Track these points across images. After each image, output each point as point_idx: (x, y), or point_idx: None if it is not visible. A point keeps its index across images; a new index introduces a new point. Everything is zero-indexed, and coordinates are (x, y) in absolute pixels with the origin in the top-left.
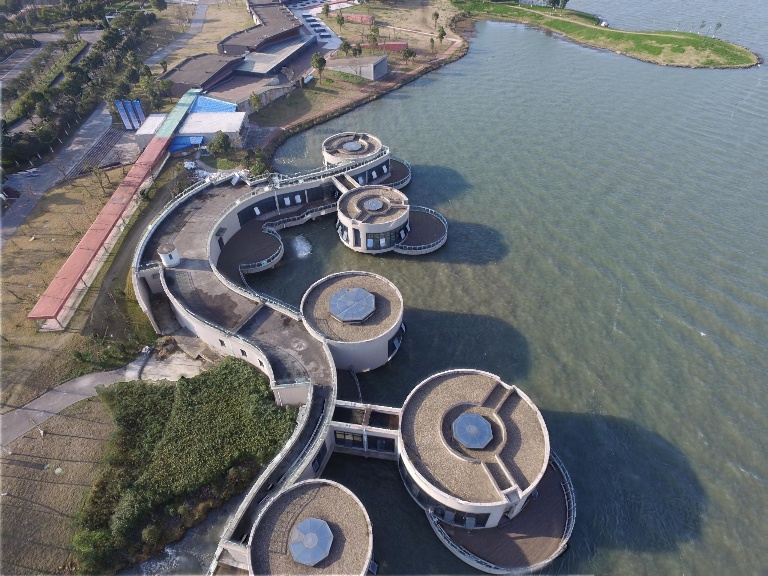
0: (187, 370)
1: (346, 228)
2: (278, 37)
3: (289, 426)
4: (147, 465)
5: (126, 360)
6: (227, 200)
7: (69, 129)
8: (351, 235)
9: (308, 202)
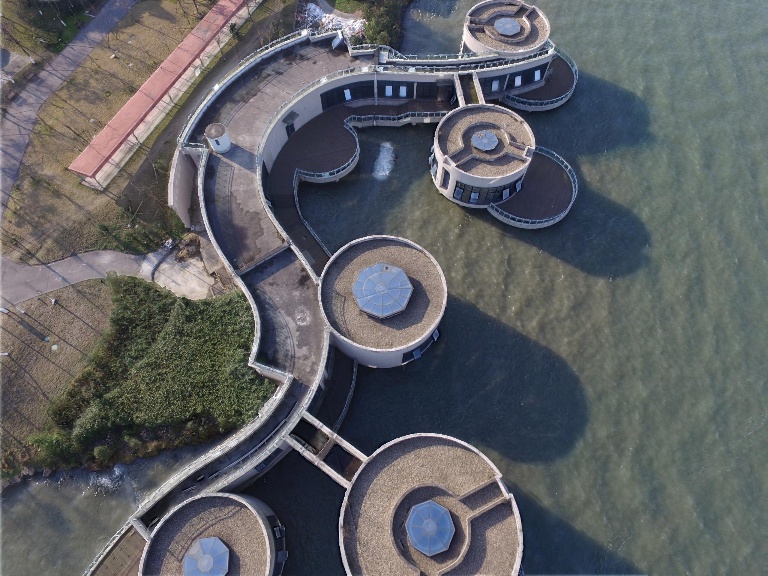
0: (197, 285)
1: (437, 162)
2: None
3: (258, 405)
4: (122, 381)
5: (148, 248)
6: (316, 71)
7: None
8: (440, 173)
9: (416, 98)
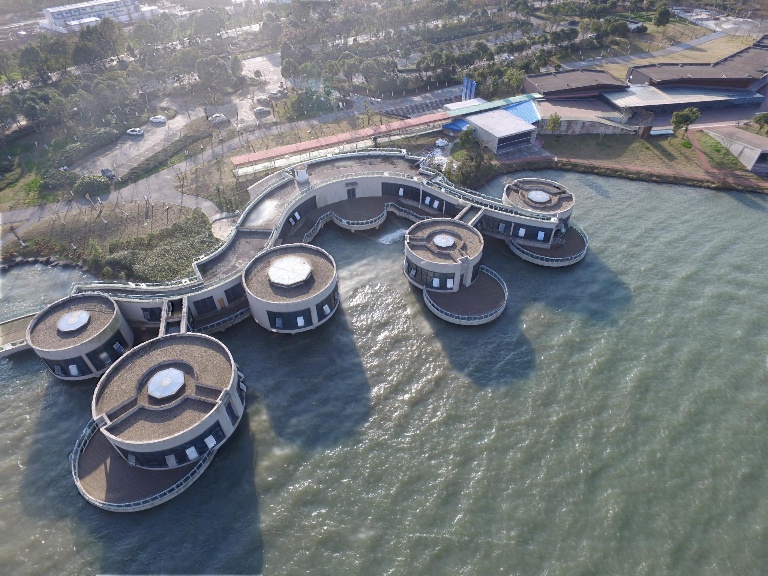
0: (227, 235)
1: None
2: (705, 82)
3: None
4: (149, 250)
5: (228, 209)
6: (391, 170)
7: (435, 87)
8: None
9: (444, 213)
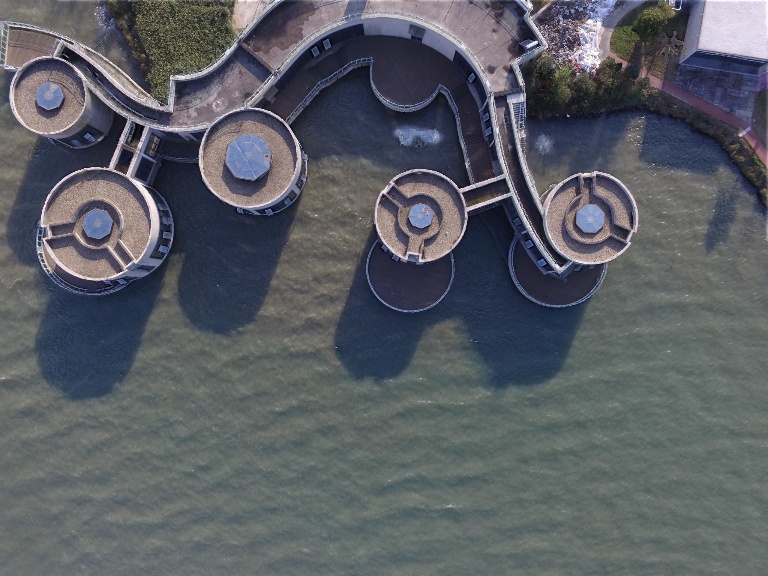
0: (248, 17)
1: None
2: None
3: (162, 97)
4: None
5: None
6: (483, 35)
7: None
8: None
9: None
